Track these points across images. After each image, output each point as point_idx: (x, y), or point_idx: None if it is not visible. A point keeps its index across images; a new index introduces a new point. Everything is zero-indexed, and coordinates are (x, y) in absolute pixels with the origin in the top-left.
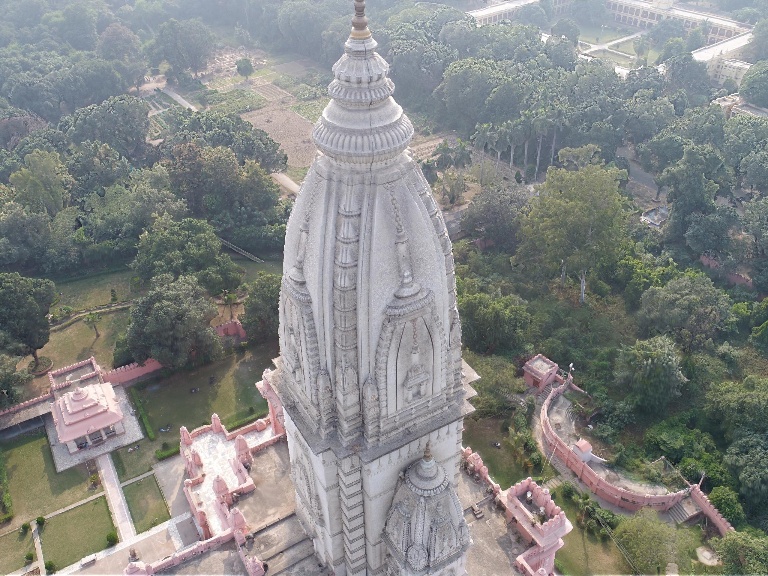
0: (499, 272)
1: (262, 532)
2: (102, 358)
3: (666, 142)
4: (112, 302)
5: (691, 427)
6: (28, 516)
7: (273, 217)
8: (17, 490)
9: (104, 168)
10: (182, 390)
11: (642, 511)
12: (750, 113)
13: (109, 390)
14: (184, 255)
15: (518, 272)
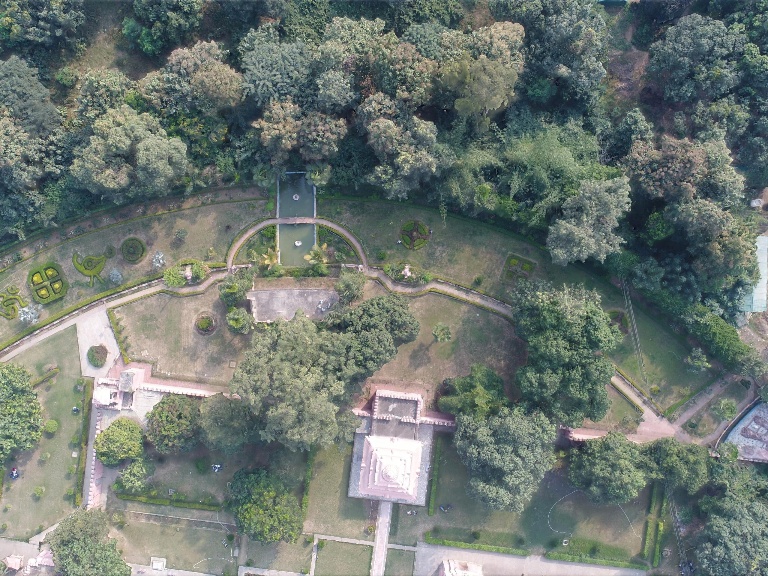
0: None
1: None
2: (431, 373)
3: None
4: (474, 288)
5: None
6: (315, 526)
7: (713, 290)
8: (315, 492)
9: (568, 74)
10: None
11: None
12: None
13: (418, 457)
14: (564, 379)
15: None
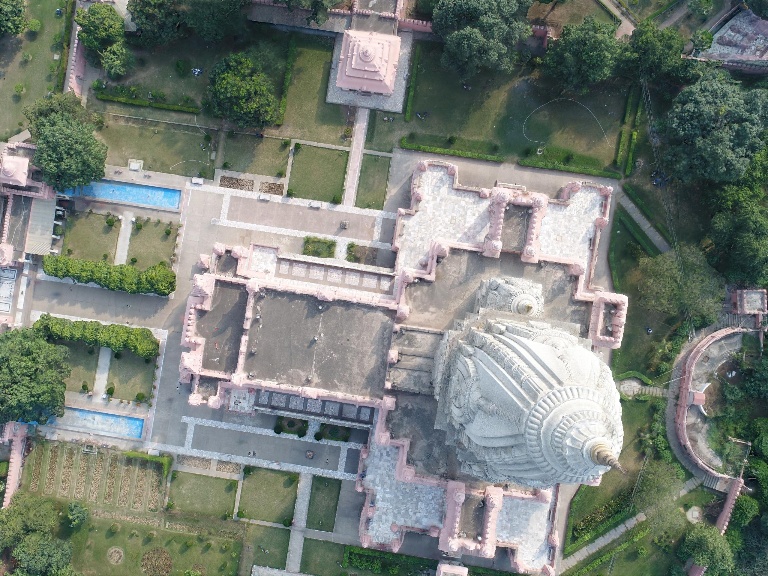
0: None
1: (413, 331)
2: None
3: None
4: None
5: None
6: (292, 131)
7: None
8: (293, 98)
9: None
10: (457, 78)
11: (673, 483)
12: None
13: (396, 50)
14: None
15: None
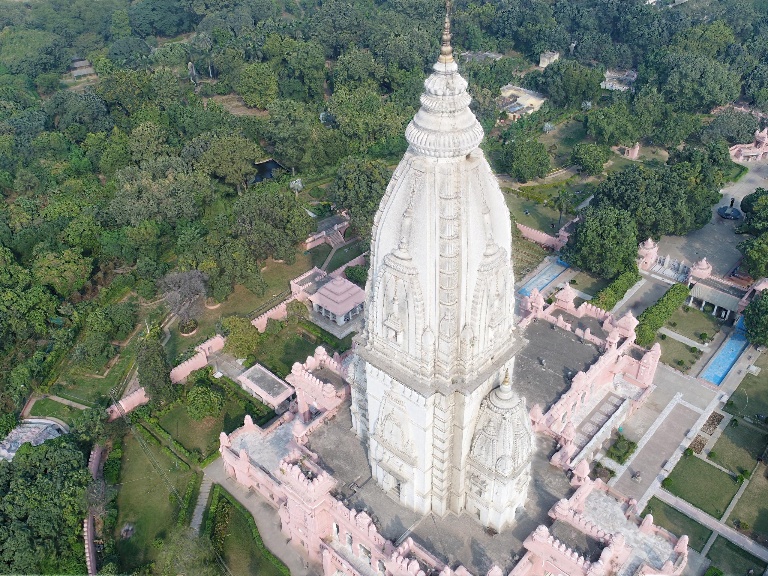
0: None
1: None
2: None
3: None
4: None
5: None
6: (759, 485)
7: None
8: None
9: None
10: None
11: None
12: None
13: None
14: None
15: None
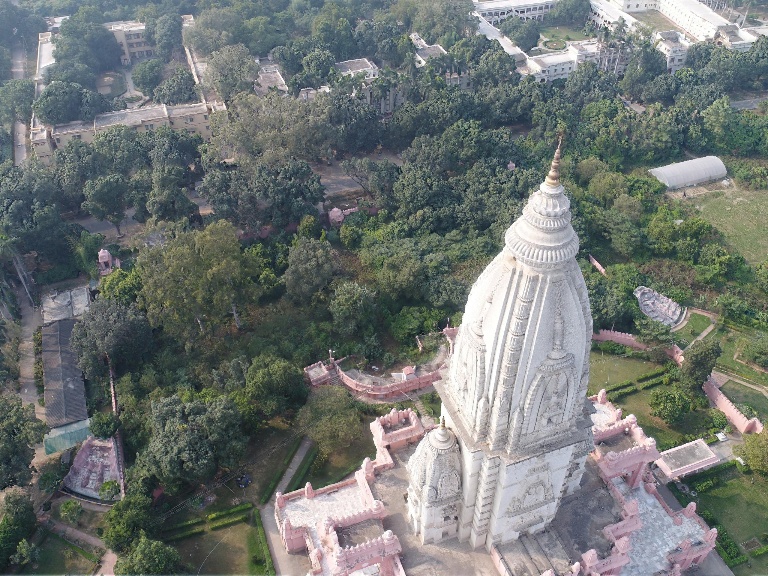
0: (177, 368)
1: (512, 574)
2: None
3: (106, 188)
4: None
5: (392, 315)
6: None
7: None
8: None
9: None
10: None
11: None
12: (72, 131)
13: None
14: None
15: (185, 354)
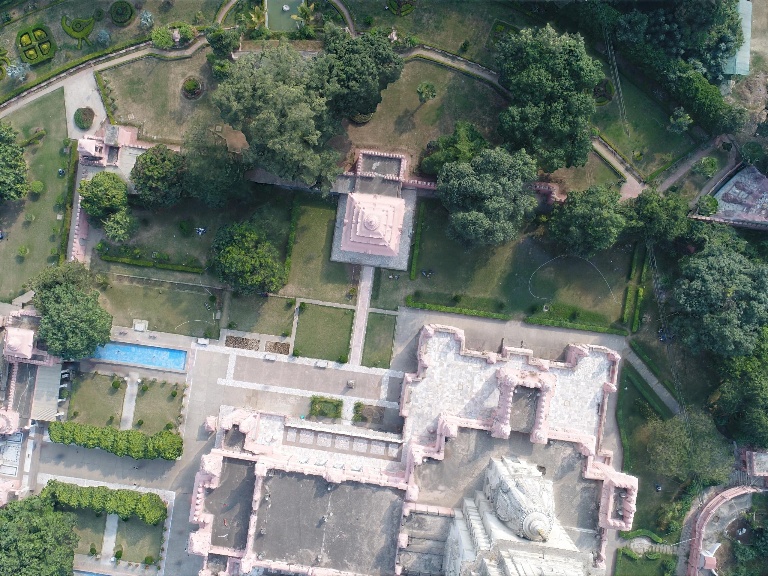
0: None
1: (423, 514)
2: (416, 138)
3: None
4: (460, 54)
5: None
6: (297, 290)
7: (696, 45)
8: (297, 256)
9: None
10: None
11: None
12: None
13: (400, 213)
14: (545, 113)
15: None
